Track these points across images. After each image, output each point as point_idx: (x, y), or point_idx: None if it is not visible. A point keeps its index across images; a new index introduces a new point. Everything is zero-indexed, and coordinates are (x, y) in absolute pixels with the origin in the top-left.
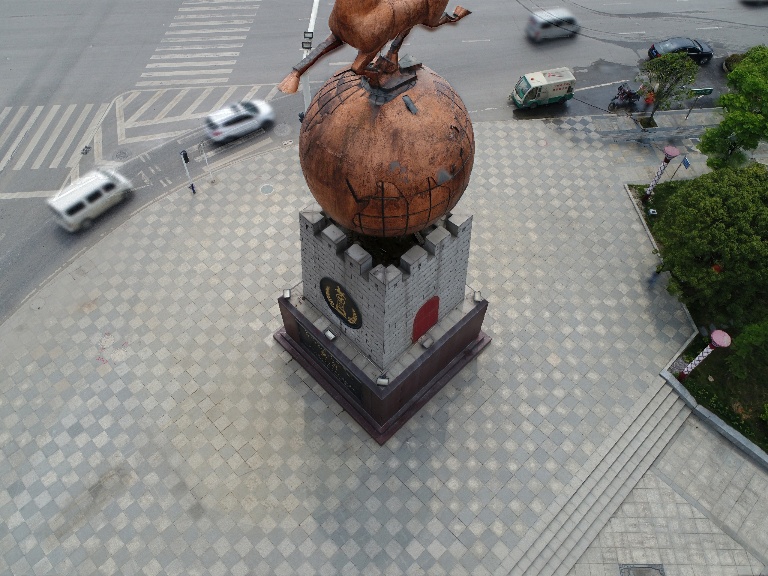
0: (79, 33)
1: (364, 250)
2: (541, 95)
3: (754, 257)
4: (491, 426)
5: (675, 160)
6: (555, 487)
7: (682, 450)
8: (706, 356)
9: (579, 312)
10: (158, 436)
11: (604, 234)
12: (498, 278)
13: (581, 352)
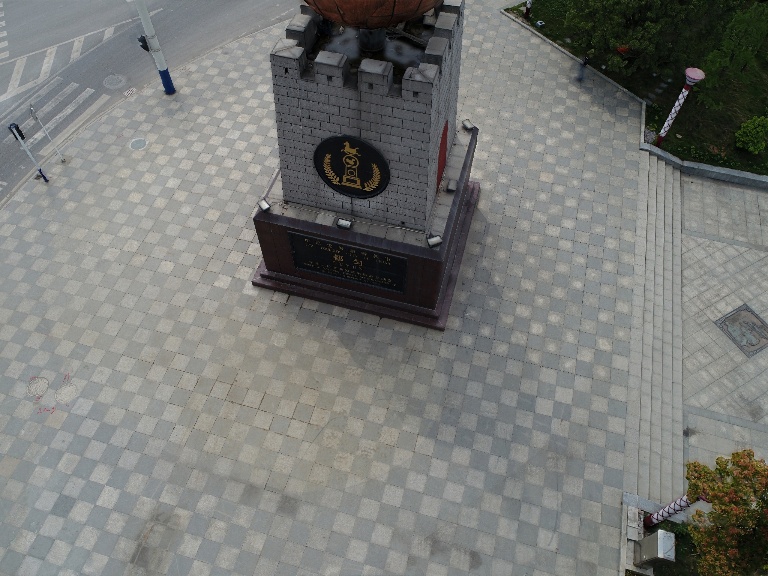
0: None
1: (379, 61)
2: None
3: None
4: (533, 260)
5: None
6: (626, 283)
7: (694, 205)
8: (682, 103)
9: (539, 128)
10: (183, 454)
11: (513, 57)
12: None
13: (565, 160)
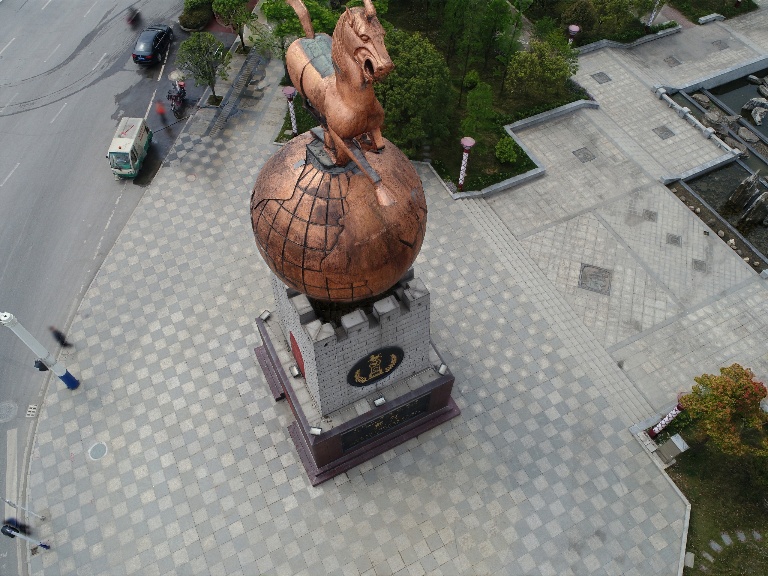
0: None
1: (384, 299)
2: (138, 152)
3: (423, 90)
4: (465, 324)
5: (266, 103)
6: (524, 299)
7: (508, 217)
8: None
9: None
10: None
11: None
12: None
13: None
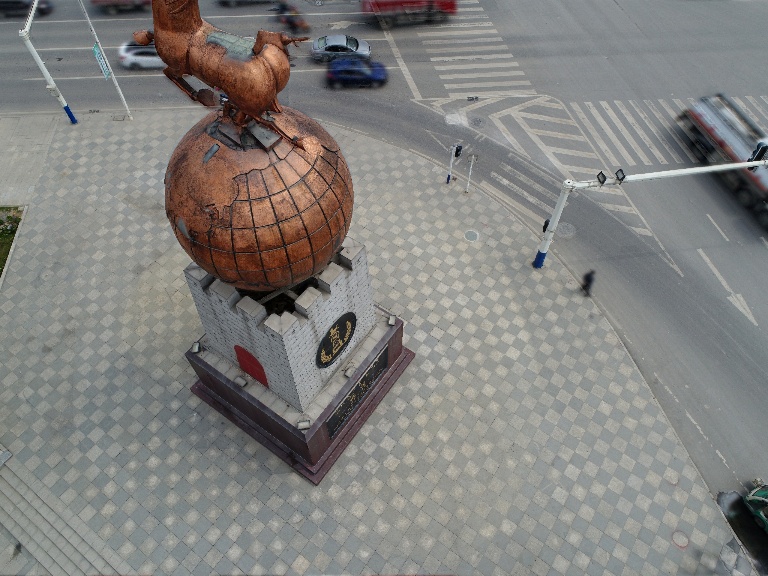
0: (619, 44)
1: None
2: None
3: None
4: (214, 494)
5: None
6: (146, 569)
7: None
8: None
9: None
10: None
11: None
12: (408, 488)
13: None
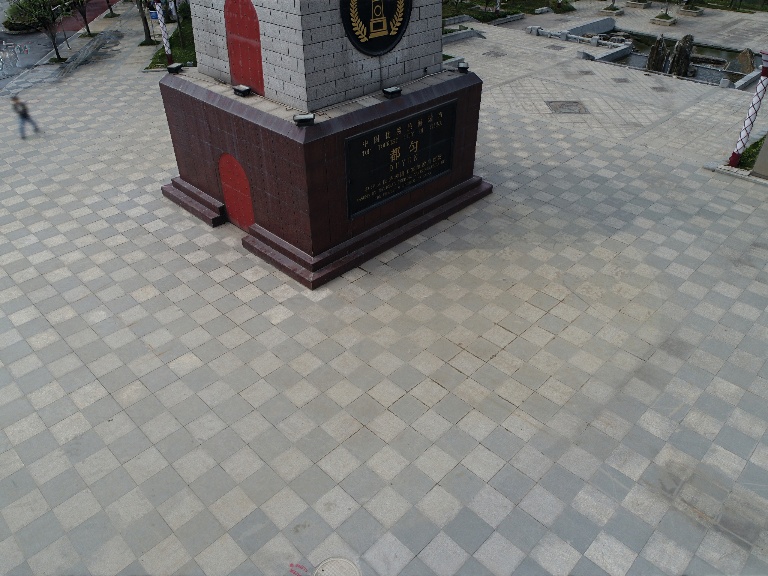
0: None
1: None
2: None
3: None
4: None
5: (125, 55)
6: (504, 113)
7: None
8: None
9: None
10: (558, 430)
11: None
12: None
13: None
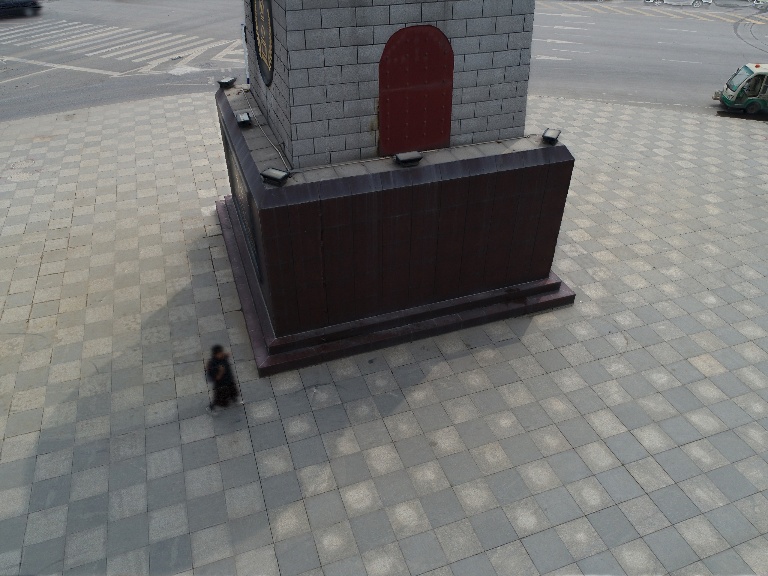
0: None
1: None
2: None
3: None
4: (509, 424)
5: None
6: None
7: None
8: None
9: None
10: None
11: None
12: (625, 236)
13: None
